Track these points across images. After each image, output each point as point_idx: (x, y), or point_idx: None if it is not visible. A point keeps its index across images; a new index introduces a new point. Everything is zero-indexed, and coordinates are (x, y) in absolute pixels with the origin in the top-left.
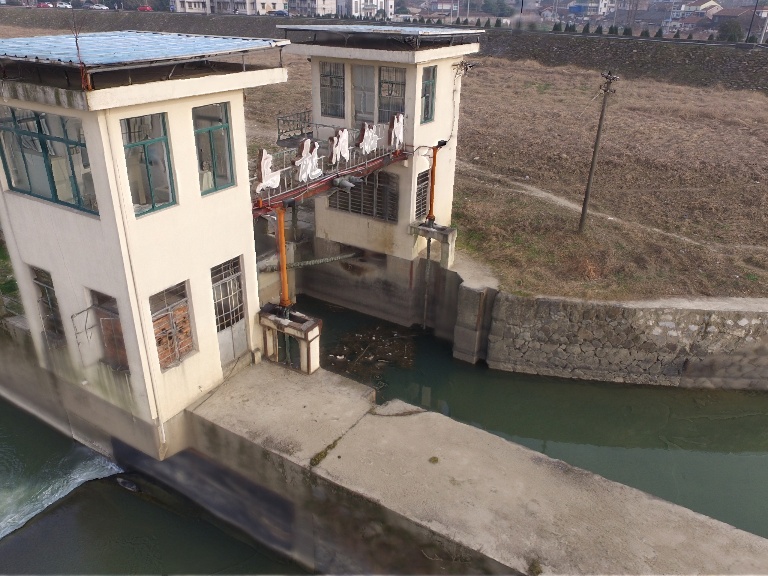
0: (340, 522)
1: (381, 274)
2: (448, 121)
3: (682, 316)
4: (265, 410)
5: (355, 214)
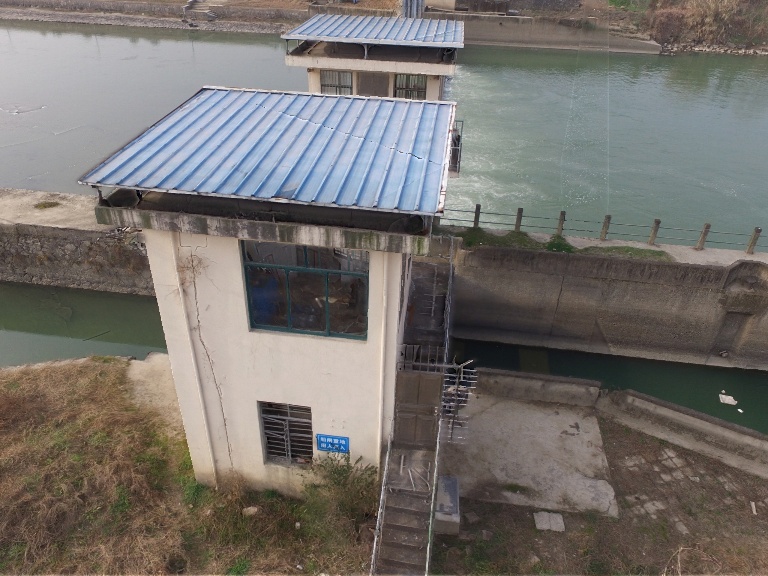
0: None
1: None
2: None
3: None
4: None
5: None
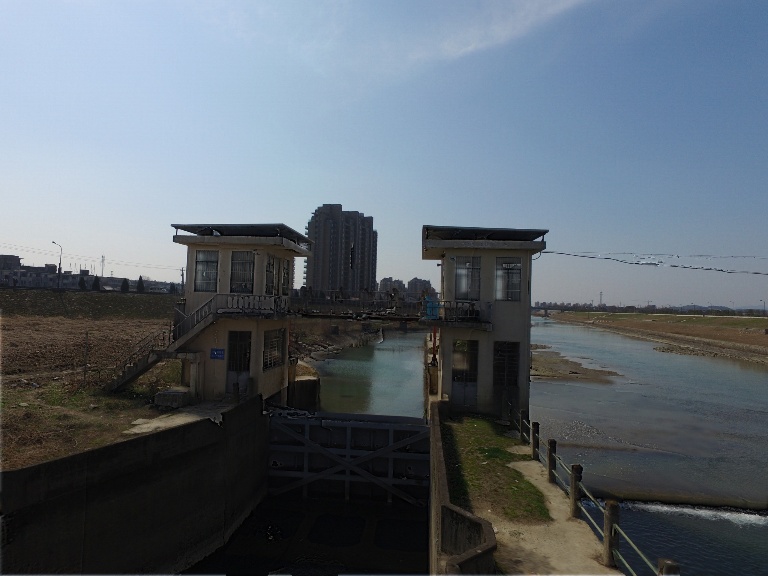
0: None
1: None
2: None
3: None
4: None
5: None
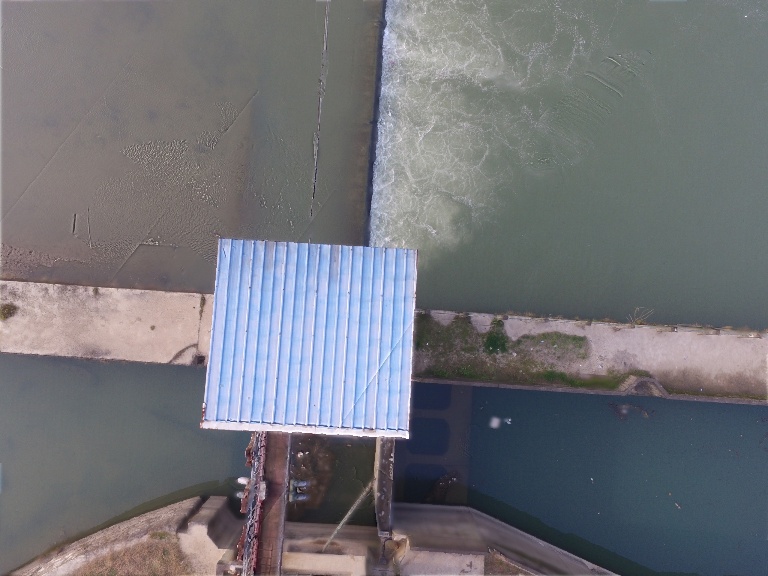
0: (191, 291)
1: (296, 542)
2: None
3: (45, 571)
4: None
5: (319, 573)
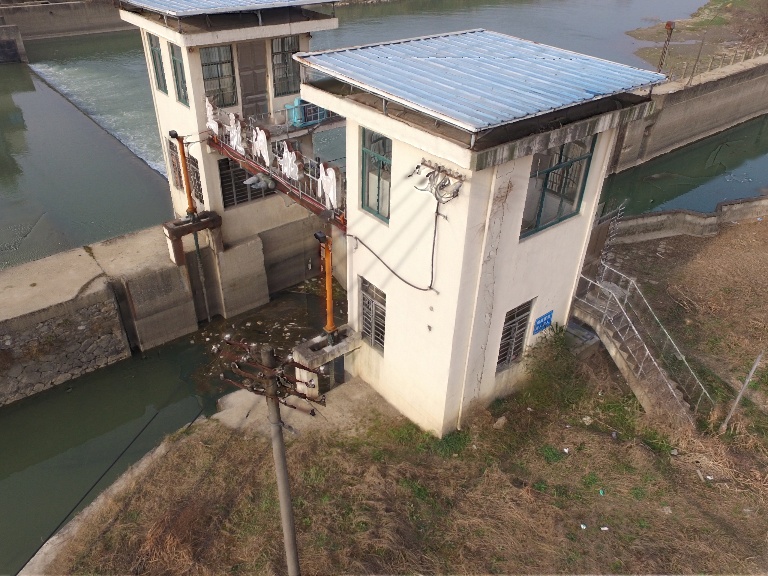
0: None
1: None
2: (429, 258)
3: None
4: (151, 239)
5: None
